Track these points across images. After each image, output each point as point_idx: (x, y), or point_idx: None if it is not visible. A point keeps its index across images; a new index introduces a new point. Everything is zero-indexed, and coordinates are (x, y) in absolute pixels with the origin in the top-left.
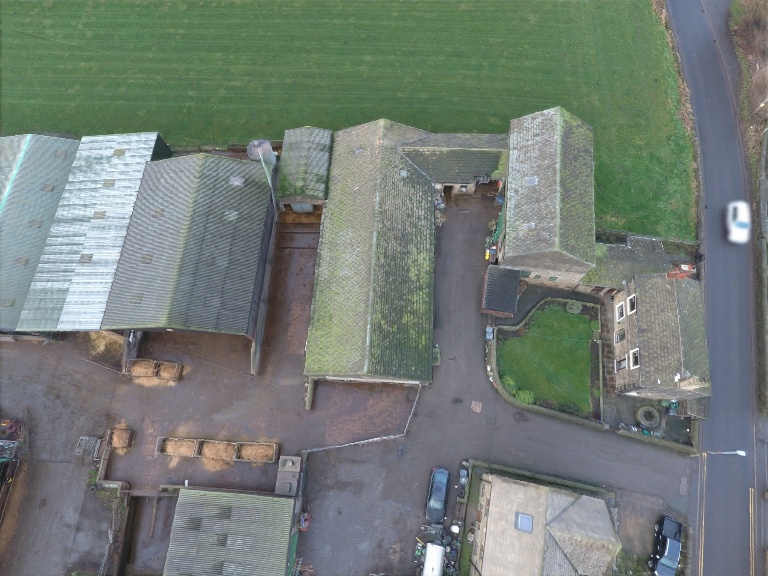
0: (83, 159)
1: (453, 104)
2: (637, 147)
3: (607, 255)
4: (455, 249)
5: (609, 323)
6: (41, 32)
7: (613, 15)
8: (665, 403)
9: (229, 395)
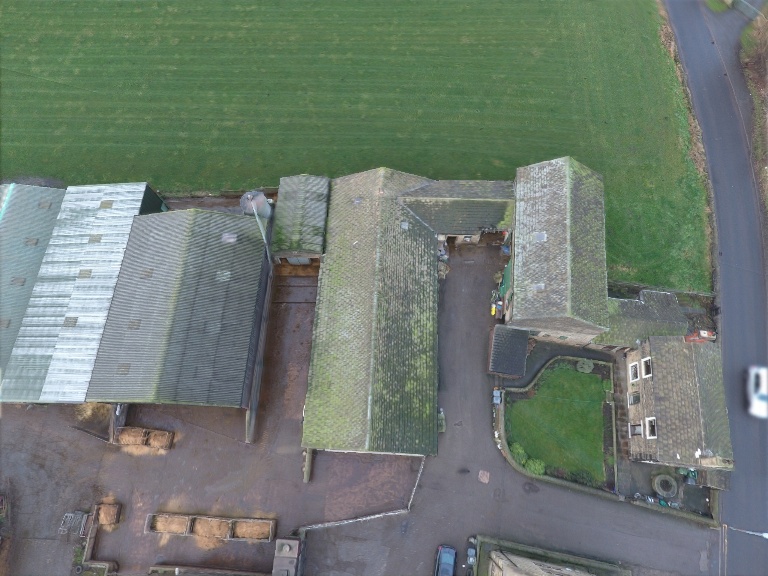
0: (68, 211)
1: (455, 145)
2: (648, 191)
3: (620, 312)
4: (459, 304)
5: (622, 382)
6: (26, 69)
7: (620, 48)
8: (683, 471)
9: (223, 464)
